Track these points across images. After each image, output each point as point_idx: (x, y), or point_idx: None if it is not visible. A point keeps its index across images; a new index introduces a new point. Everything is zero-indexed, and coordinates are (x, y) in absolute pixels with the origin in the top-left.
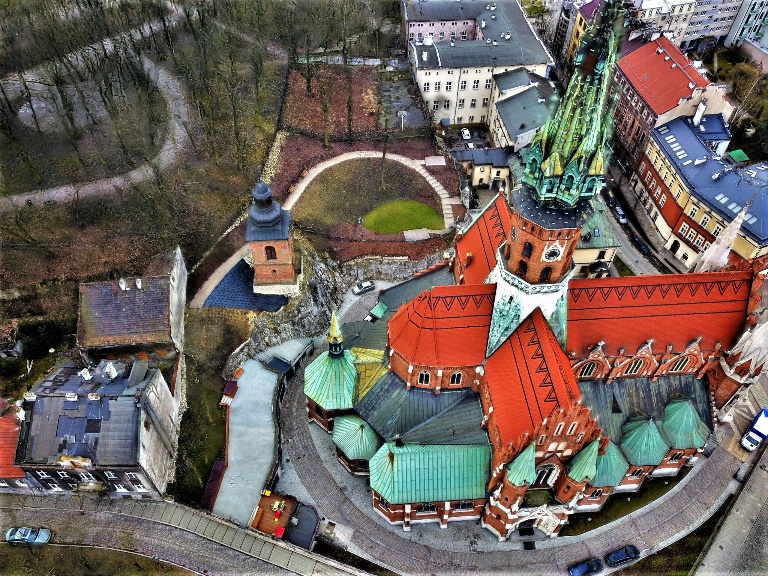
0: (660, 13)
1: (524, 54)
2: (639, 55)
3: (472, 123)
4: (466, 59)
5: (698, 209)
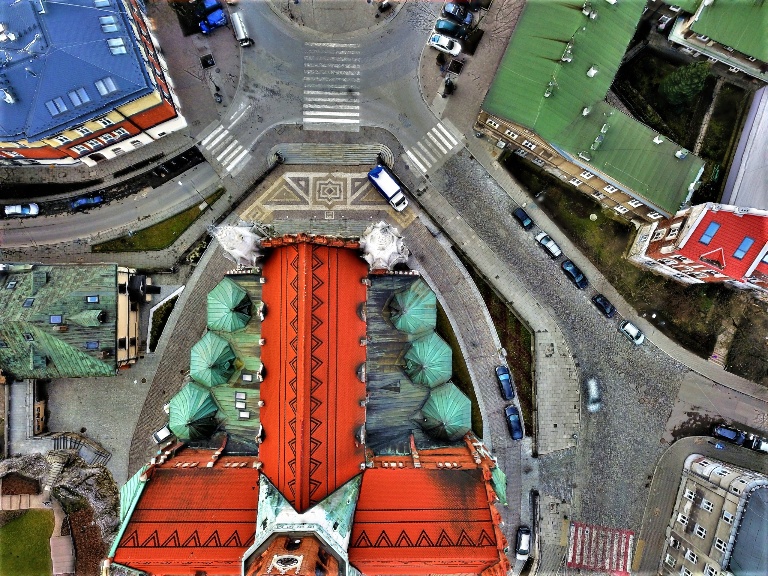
0: None
1: None
2: None
3: None
4: None
5: None
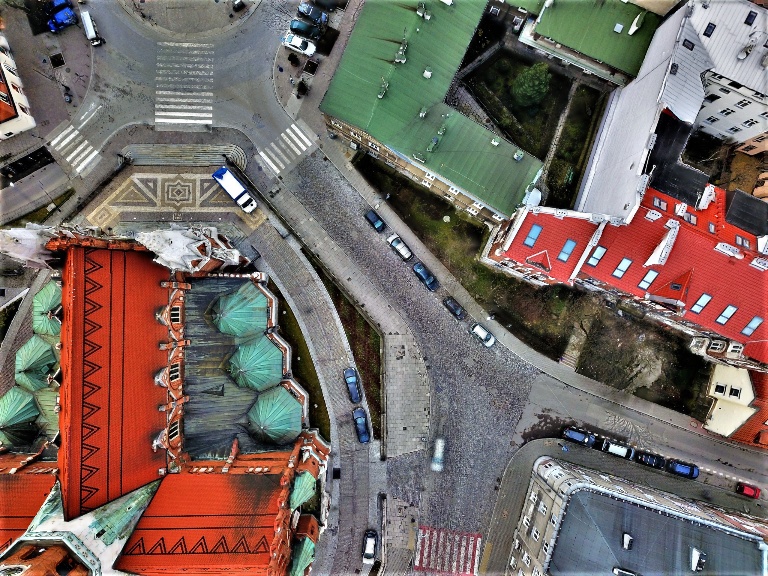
0: None
1: None
2: None
3: None
4: None
5: None
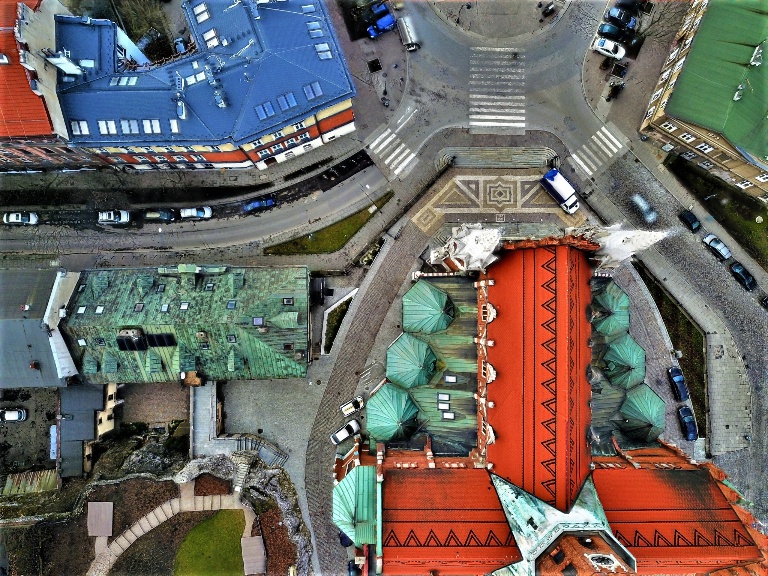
0: None
1: None
2: None
3: None
4: None
5: None
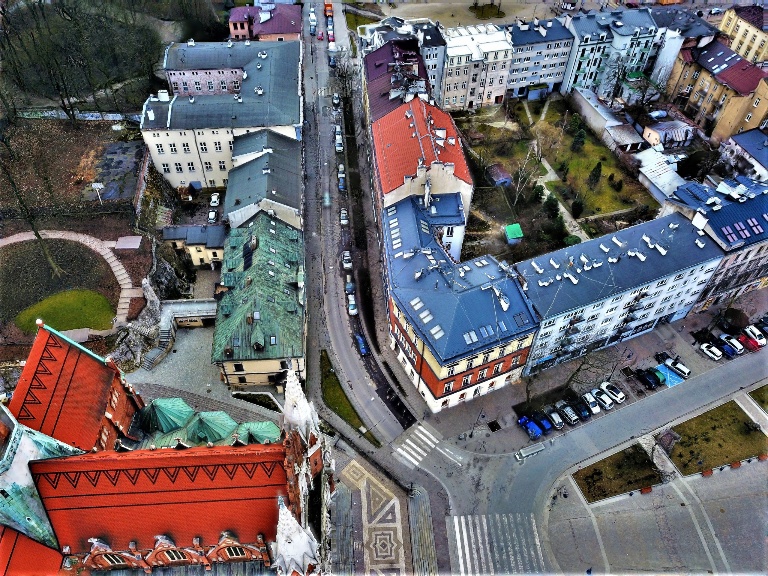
0: (471, 60)
1: (270, 113)
2: (391, 118)
3: None
4: (201, 119)
5: (400, 312)
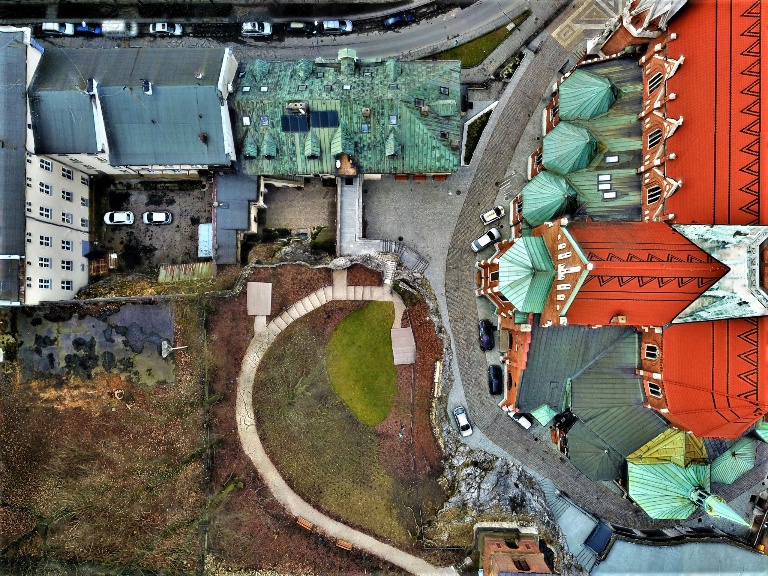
0: None
1: None
2: None
3: (89, 201)
4: None
5: None
